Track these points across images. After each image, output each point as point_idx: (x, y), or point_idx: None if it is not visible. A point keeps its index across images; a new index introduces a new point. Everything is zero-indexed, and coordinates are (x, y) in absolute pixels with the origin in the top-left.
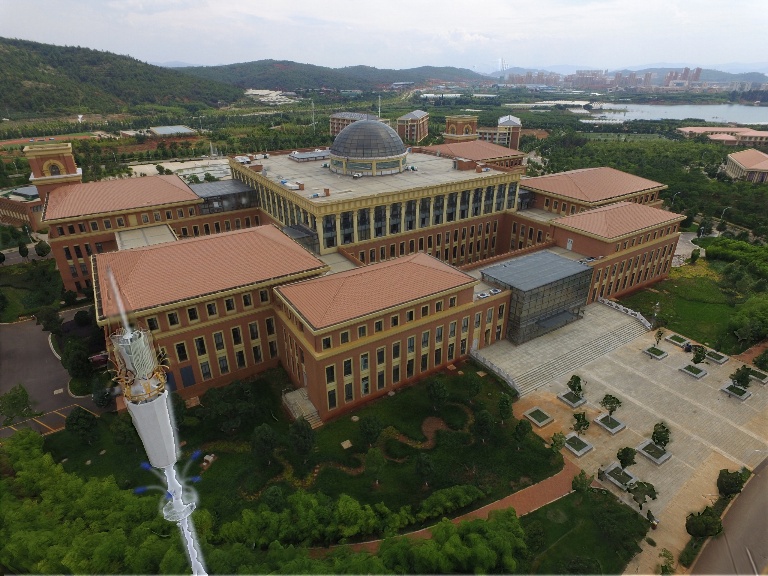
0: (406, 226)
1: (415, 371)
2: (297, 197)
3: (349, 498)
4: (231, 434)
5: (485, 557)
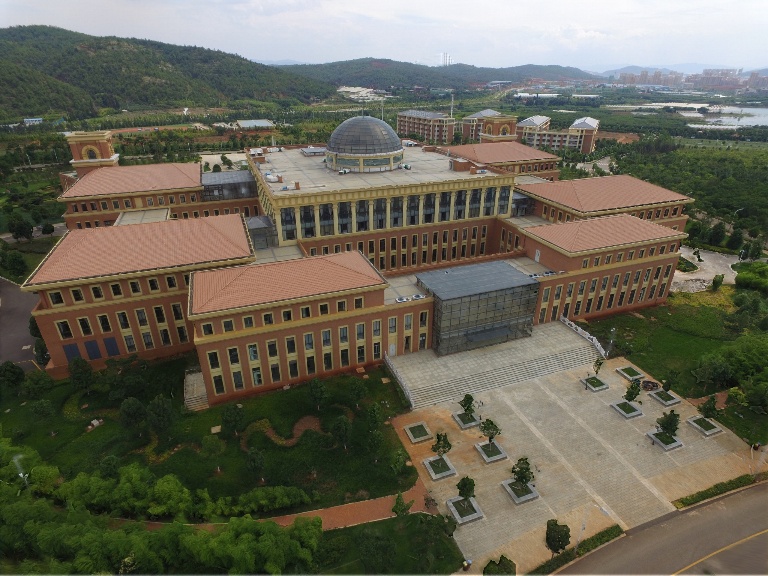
0: (376, 224)
1: (317, 369)
2: None
3: (170, 479)
4: None
5: (240, 558)
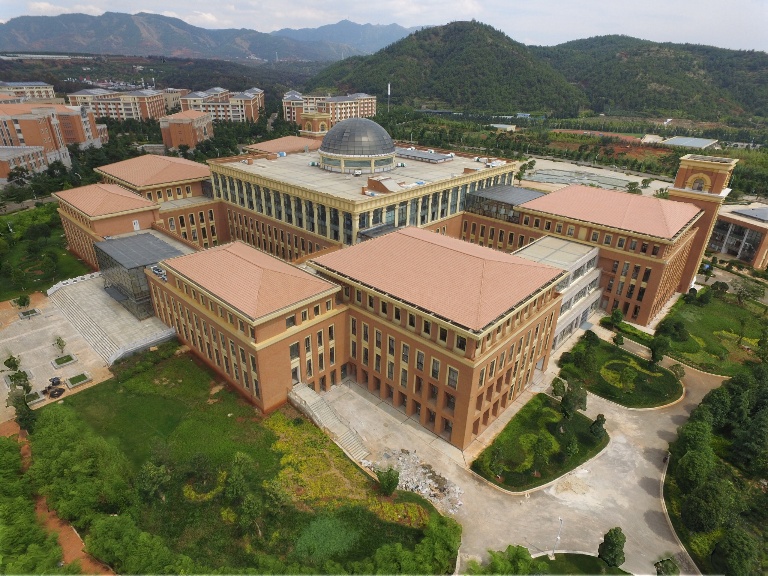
0: (259, 207)
1: None
2: None
3: None
4: None
5: None
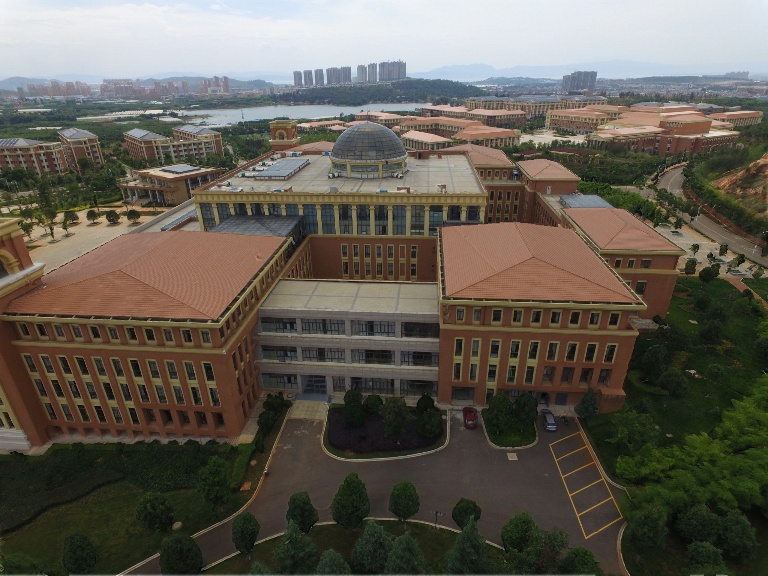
0: None
1: None
2: (440, 197)
3: None
4: (663, 359)
5: None
